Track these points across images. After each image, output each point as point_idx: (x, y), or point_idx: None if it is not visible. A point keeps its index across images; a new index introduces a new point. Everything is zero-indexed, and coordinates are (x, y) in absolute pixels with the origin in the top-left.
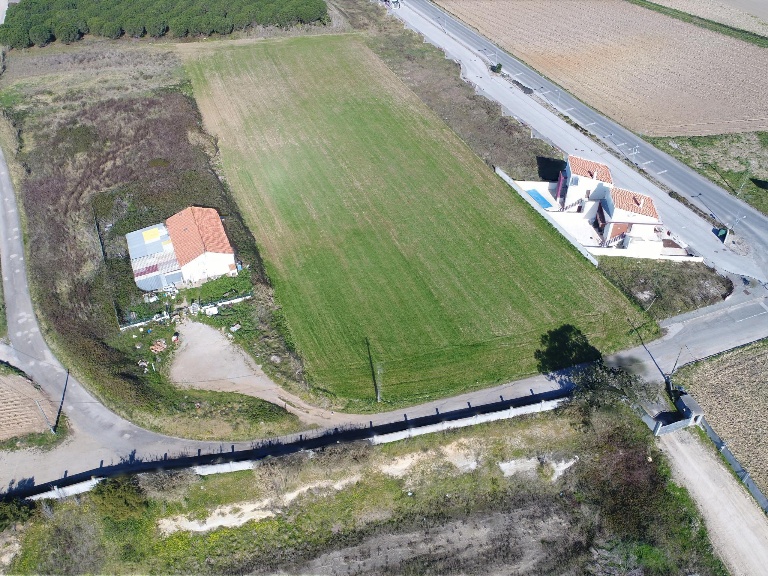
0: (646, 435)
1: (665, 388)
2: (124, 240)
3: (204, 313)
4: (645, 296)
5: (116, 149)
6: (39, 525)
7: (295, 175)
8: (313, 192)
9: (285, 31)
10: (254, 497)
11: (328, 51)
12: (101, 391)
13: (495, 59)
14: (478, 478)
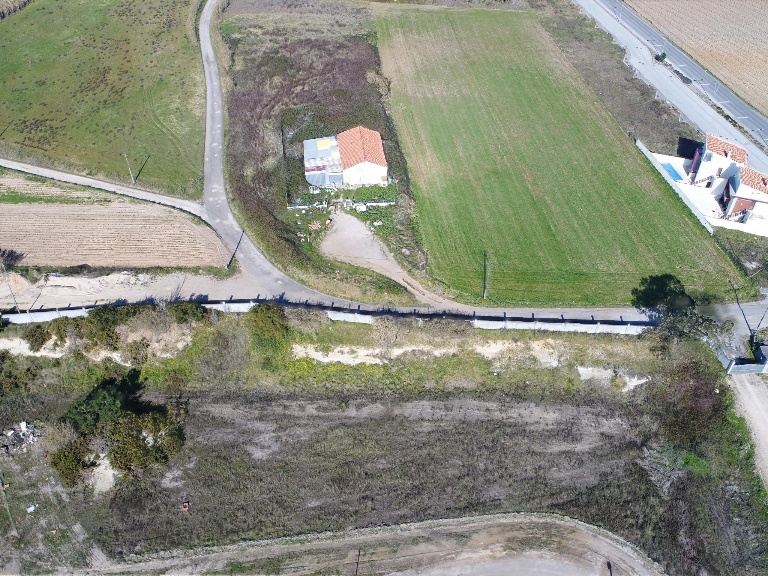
0: (719, 371)
1: (749, 340)
2: (301, 146)
3: (355, 209)
4: (752, 266)
5: (306, 77)
6: (207, 327)
7: (451, 120)
8: (464, 135)
9: (468, 2)
10: (369, 344)
11: (503, 24)
12: (266, 248)
13: (662, 49)
14: (557, 374)
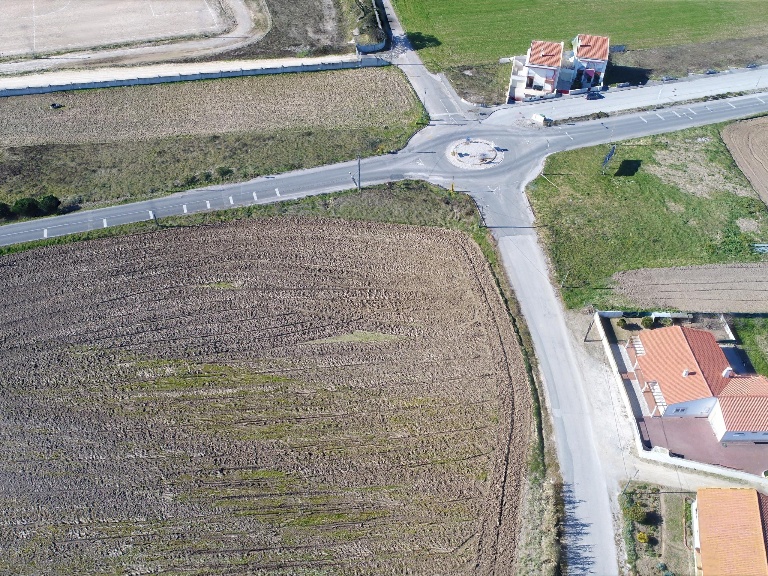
0: None
1: None
2: None
3: None
4: (468, 73)
5: None
6: None
7: None
8: None
9: None
10: None
11: None
12: None
13: None
14: None
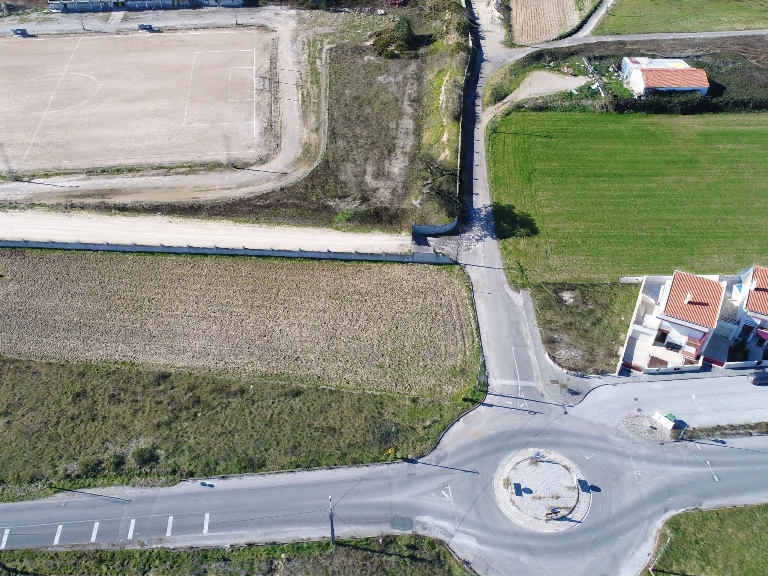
0: None
1: None
2: None
3: (594, 84)
4: (566, 297)
5: None
6: None
7: None
8: (763, 151)
9: None
10: None
11: None
12: None
13: None
14: None
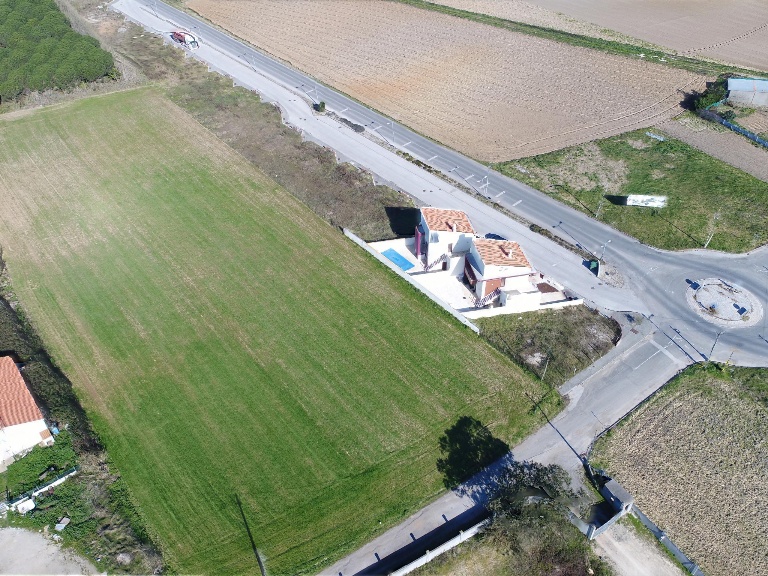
0: (580, 542)
1: (585, 473)
2: None
3: (16, 512)
4: (536, 360)
5: None
6: None
7: (109, 282)
8: (135, 301)
9: (67, 94)
10: None
11: (124, 112)
12: None
13: (316, 96)
14: None
